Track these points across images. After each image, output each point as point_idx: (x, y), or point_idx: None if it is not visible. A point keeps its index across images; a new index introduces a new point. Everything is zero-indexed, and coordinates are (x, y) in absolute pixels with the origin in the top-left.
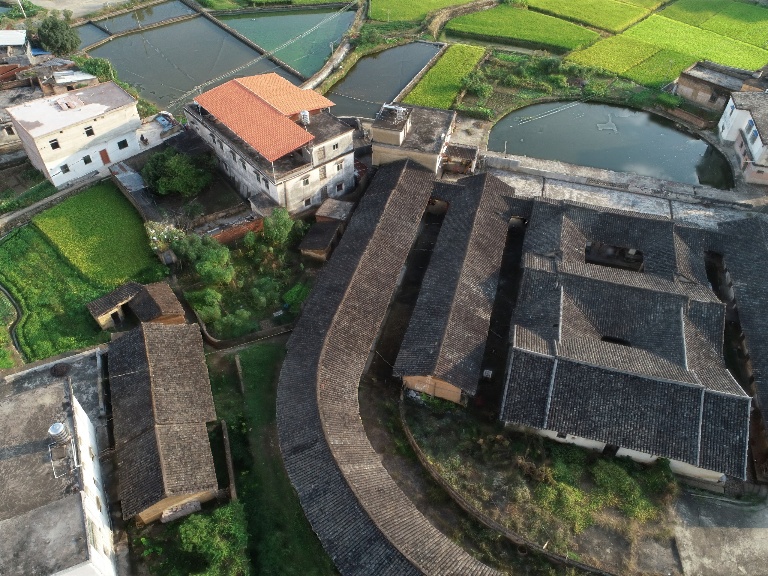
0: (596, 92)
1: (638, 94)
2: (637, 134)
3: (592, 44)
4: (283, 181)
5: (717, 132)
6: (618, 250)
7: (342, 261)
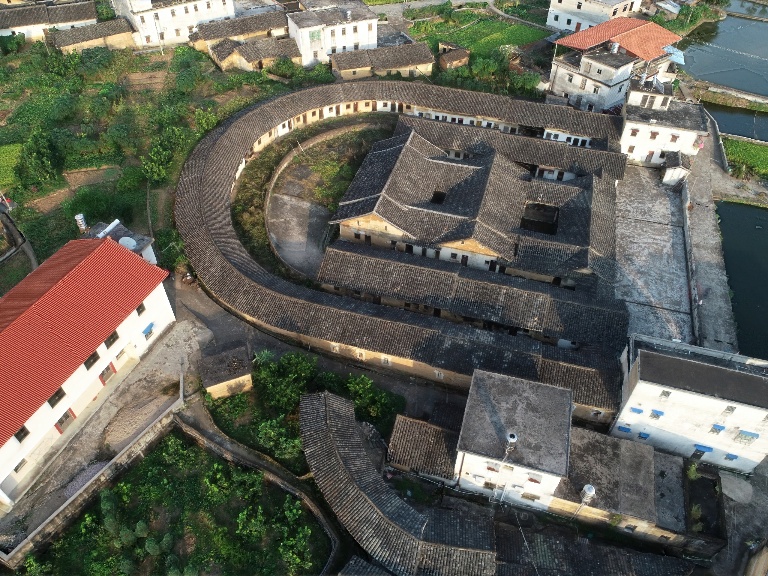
0: None
1: None
2: None
3: None
4: (557, 64)
5: None
6: None
7: None
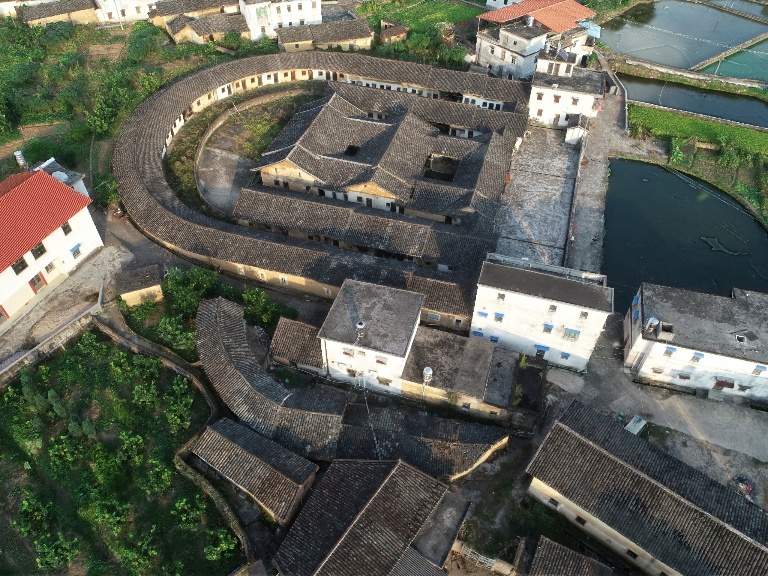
0: None
1: None
2: (705, 263)
3: None
4: (480, 37)
5: None
6: None
7: None
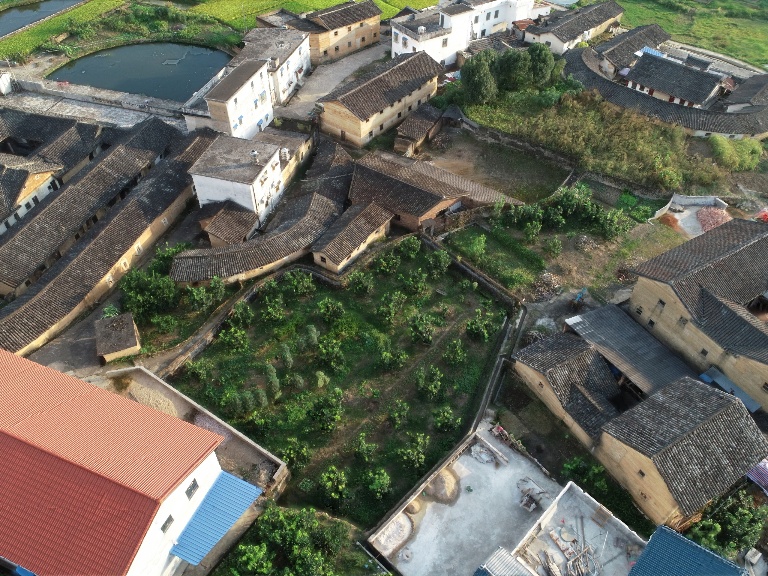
0: (184, 34)
1: (219, 36)
2: (190, 67)
3: None
4: None
5: None
6: None
7: None
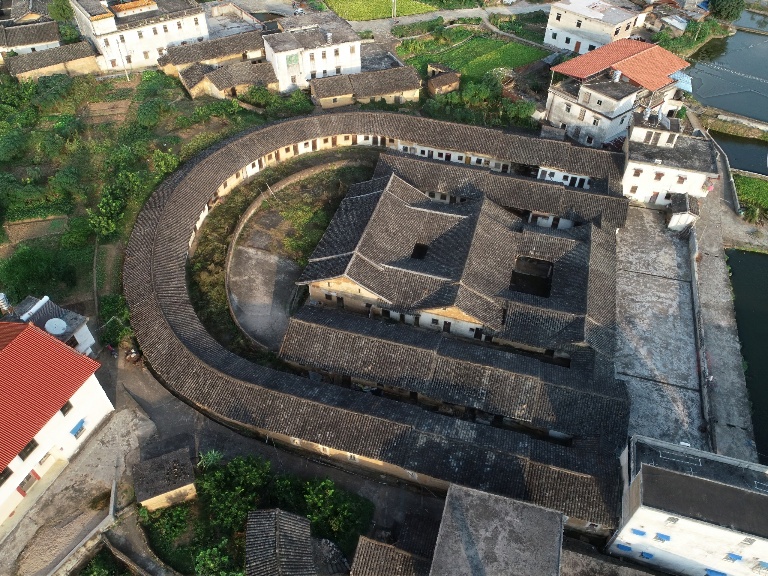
0: None
1: None
2: None
3: None
4: (553, 92)
5: None
6: None
7: None
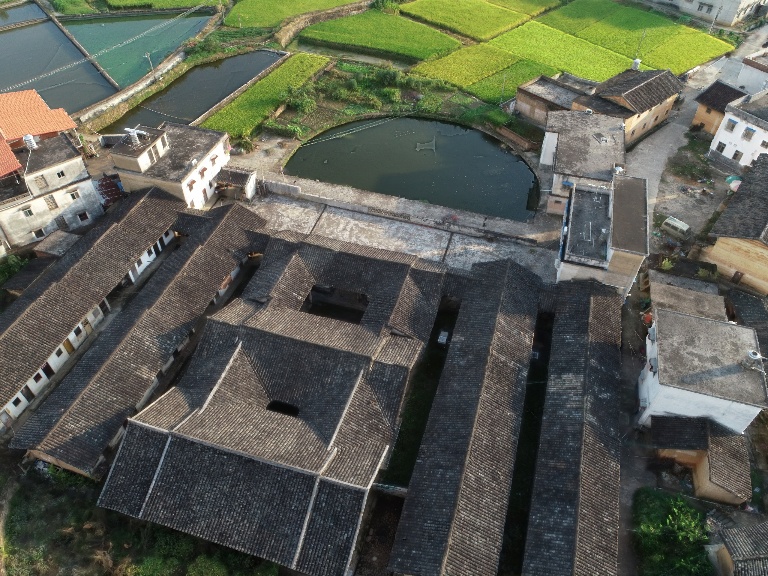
0: (426, 108)
1: (471, 110)
2: (454, 155)
3: (451, 53)
4: None
5: (539, 154)
6: (357, 293)
7: (17, 307)
